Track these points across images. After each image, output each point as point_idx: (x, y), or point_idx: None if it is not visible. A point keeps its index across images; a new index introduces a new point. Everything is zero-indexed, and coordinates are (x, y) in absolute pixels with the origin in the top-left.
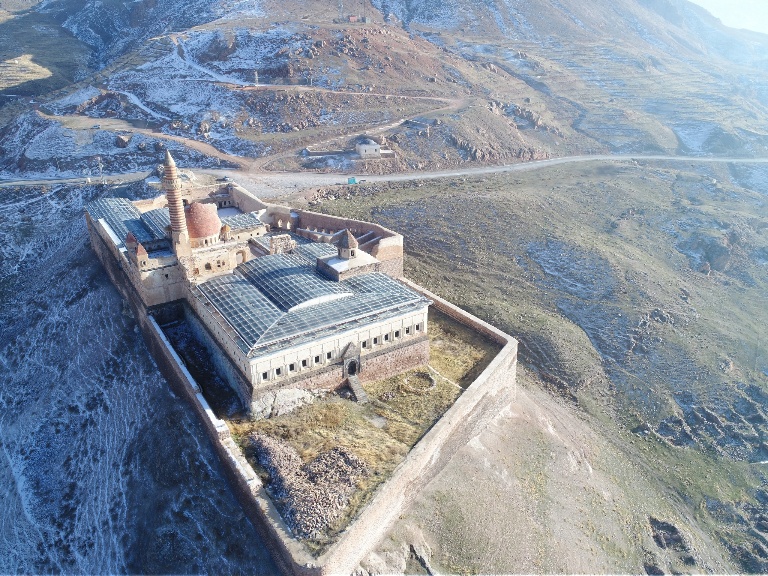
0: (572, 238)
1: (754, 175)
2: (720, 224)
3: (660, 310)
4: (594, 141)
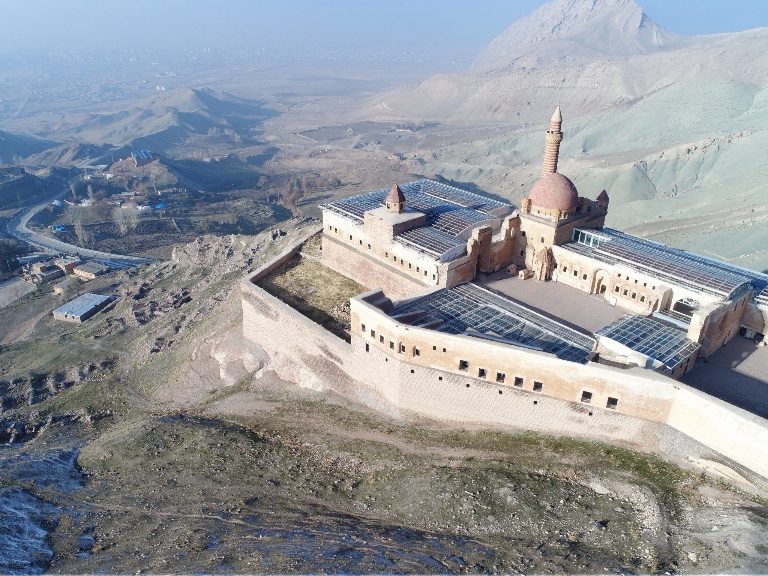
0: None
1: None
2: None
3: None
4: None
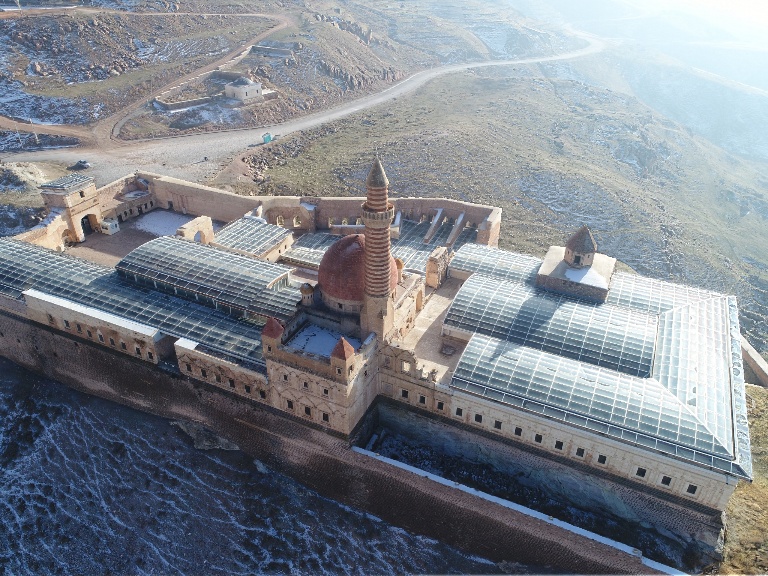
0: (551, 167)
1: (559, 73)
2: (630, 127)
3: (667, 225)
4: (423, 53)
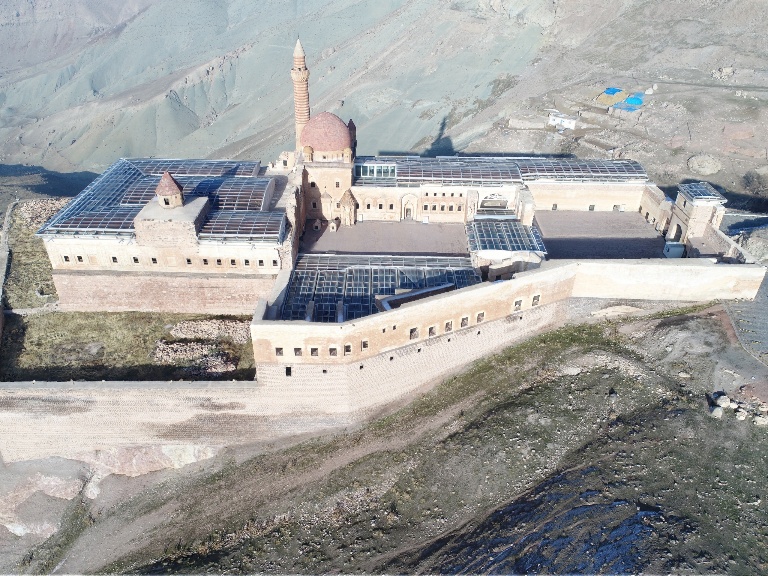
0: None
1: None
2: None
3: None
4: None
